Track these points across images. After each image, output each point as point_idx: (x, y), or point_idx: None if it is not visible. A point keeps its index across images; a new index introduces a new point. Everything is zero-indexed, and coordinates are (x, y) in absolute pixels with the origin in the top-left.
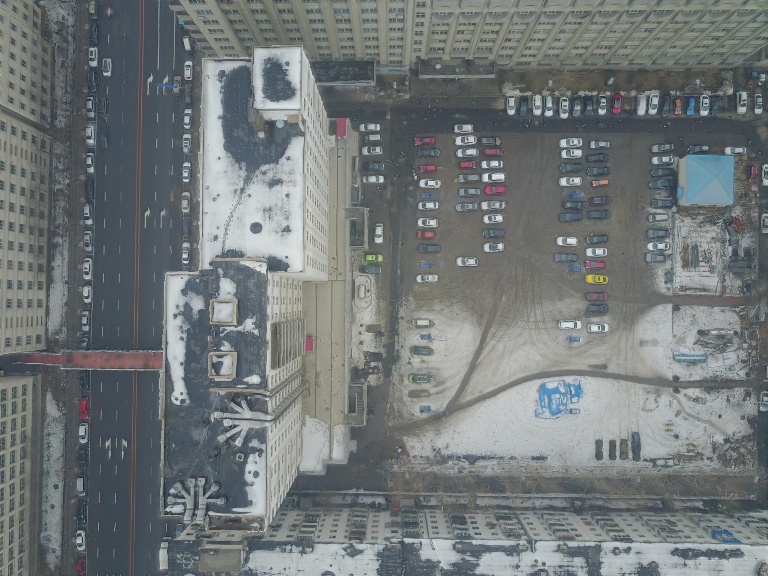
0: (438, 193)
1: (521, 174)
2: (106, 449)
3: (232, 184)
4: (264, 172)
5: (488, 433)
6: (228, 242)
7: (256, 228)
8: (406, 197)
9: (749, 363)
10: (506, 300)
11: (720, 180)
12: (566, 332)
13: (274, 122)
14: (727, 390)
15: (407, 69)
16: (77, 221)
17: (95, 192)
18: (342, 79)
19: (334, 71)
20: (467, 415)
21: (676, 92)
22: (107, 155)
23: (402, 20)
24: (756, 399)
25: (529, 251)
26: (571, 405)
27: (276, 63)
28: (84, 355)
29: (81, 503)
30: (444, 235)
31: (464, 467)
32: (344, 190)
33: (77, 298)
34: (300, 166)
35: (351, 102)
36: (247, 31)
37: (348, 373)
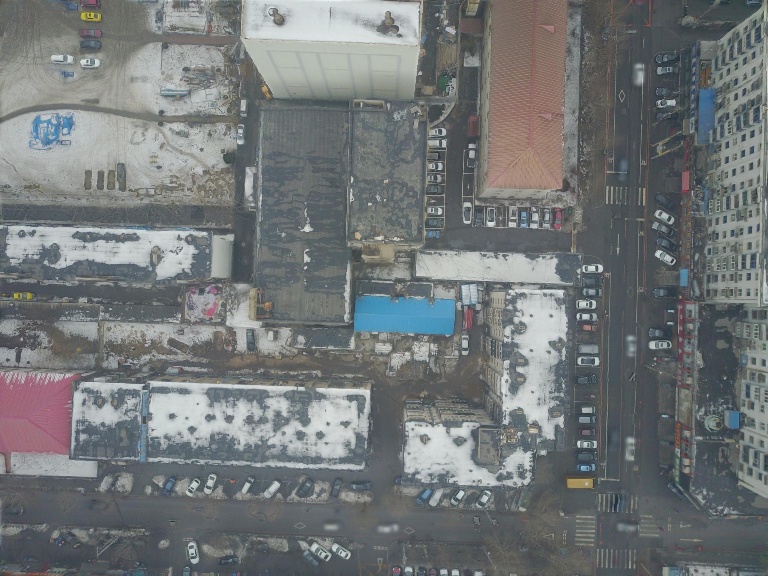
0: None
1: None
2: None
3: None
4: None
5: None
6: None
7: None
8: None
9: (230, 99)
10: (7, 36)
11: None
12: (62, 67)
13: None
14: (209, 125)
15: None
16: None
17: None
18: None
19: None
20: None
21: None
22: None
23: None
24: (236, 133)
25: None
26: (63, 137)
27: None
28: None
29: None
30: None
31: None
32: None
33: None
34: None
35: None
36: None
37: None
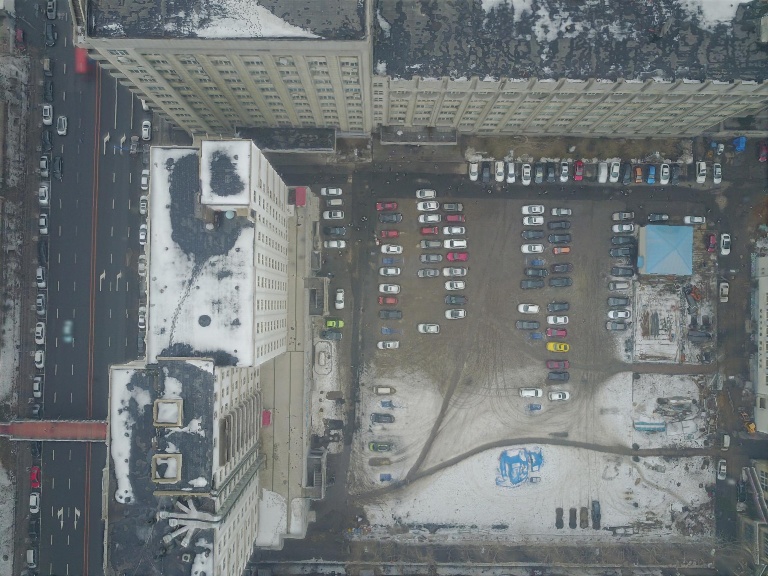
0: (399, 260)
1: (483, 240)
2: (58, 519)
3: (180, 275)
4: (213, 263)
5: (449, 502)
6: (175, 335)
7: (205, 321)
8: (368, 262)
9: (707, 431)
10: (468, 367)
11: (679, 251)
12: (527, 400)
13: (224, 213)
14: (686, 458)
15: (369, 134)
16: (30, 284)
17: (49, 254)
18: (302, 147)
19: (294, 138)
20: (428, 483)
21: (637, 160)
22: (61, 216)
23: (359, 98)
24: (714, 467)
25: (491, 318)
26: (532, 473)
27: (225, 157)
28: (35, 425)
29: (31, 575)
30: (406, 301)
31: (424, 536)
32: (303, 259)
33: (29, 363)
34: (250, 258)
35: (313, 165)
36: (203, 103)
37: (307, 444)
